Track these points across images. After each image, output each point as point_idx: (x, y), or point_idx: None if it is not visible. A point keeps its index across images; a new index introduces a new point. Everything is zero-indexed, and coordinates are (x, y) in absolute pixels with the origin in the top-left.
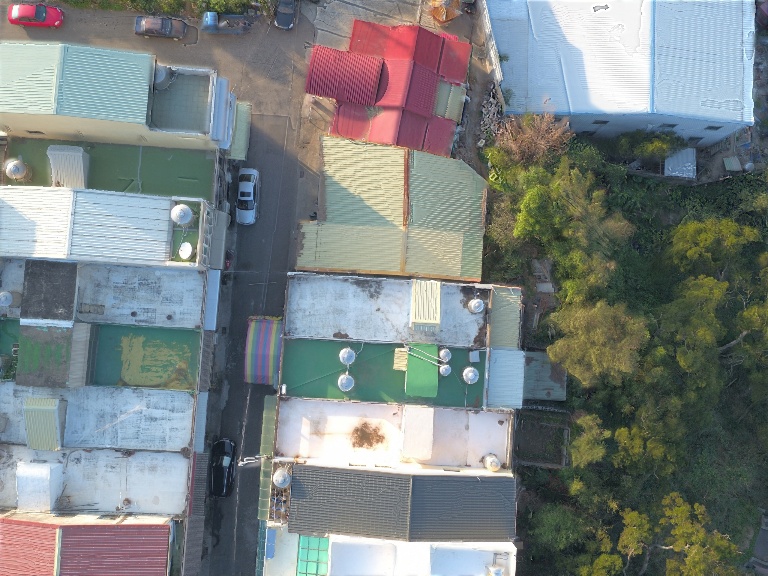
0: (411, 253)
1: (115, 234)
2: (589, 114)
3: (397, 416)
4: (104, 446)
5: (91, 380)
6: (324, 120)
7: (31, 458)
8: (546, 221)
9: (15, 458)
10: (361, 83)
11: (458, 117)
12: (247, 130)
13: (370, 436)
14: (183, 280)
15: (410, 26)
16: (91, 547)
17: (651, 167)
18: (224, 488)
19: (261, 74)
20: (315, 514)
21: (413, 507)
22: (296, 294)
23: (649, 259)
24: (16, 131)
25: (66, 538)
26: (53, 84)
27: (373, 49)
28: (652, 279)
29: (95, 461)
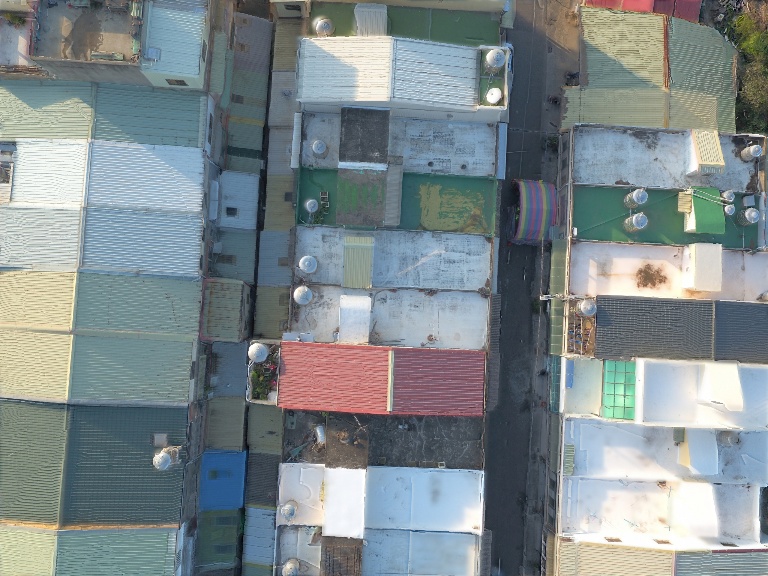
0: (674, 112)
1: (429, 80)
2: None
3: (678, 258)
4: (408, 286)
5: None
6: None
7: None
8: None
9: (326, 298)
10: None
11: None
12: (514, 1)
13: (653, 276)
14: (474, 133)
15: None
16: (419, 369)
17: None
18: None
19: None
20: (608, 347)
21: (717, 329)
22: (579, 145)
23: None
24: None
25: (398, 359)
26: None
27: None
28: None
29: (400, 301)
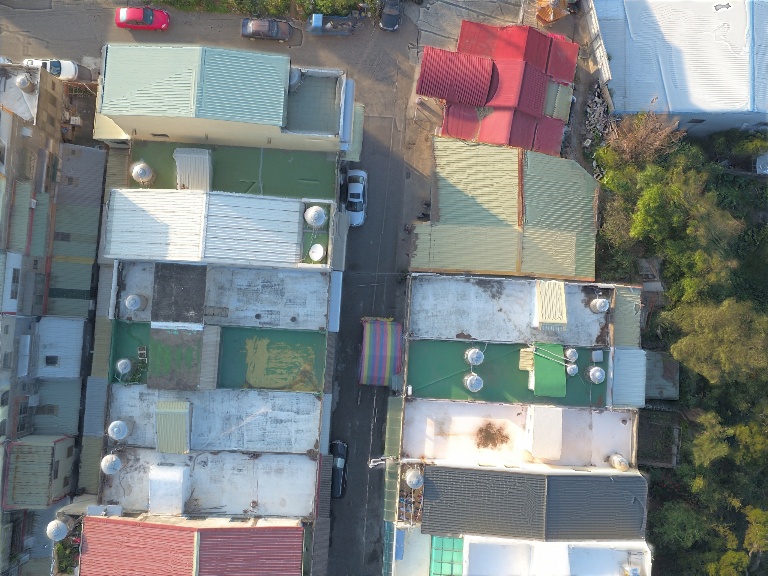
0: (527, 253)
1: (246, 236)
2: (688, 113)
3: (521, 416)
4: (231, 449)
5: (218, 383)
6: (429, 121)
7: (158, 461)
8: (664, 220)
9: (142, 461)
10: (472, 84)
11: (566, 117)
12: (360, 131)
13: (494, 437)
14: (306, 282)
15: (519, 26)
16: (228, 550)
17: (743, 166)
18: (340, 490)
19: (366, 75)
20: (443, 515)
21: (549, 507)
22: (418, 295)
23: (742, 258)
24: (140, 134)
25: (204, 541)
26: (191, 87)
27: (481, 50)
28: (747, 277)
29: (222, 464)
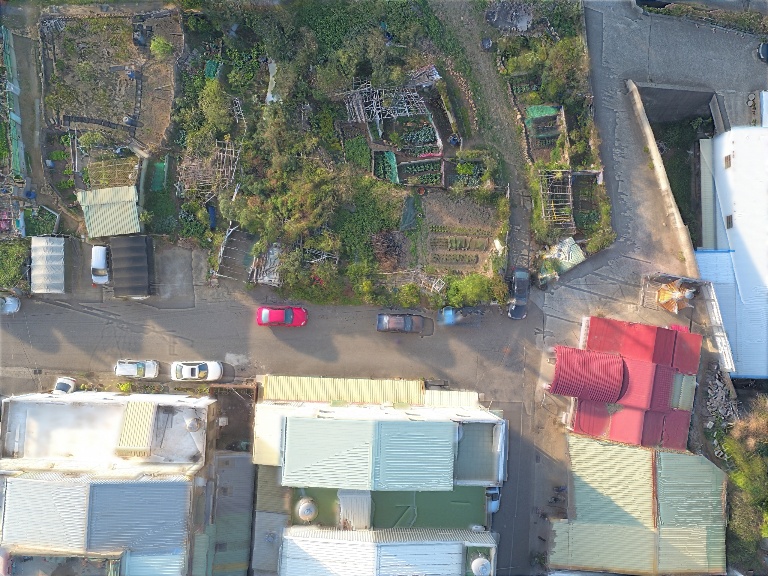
0: (663, 554)
1: None
2: None
3: None
4: None
5: None
6: (557, 405)
7: None
8: None
9: None
10: (605, 385)
11: (690, 405)
12: None
13: None
14: None
15: (647, 325)
16: None
17: None
18: None
19: (495, 362)
20: None
21: None
22: None
23: None
24: None
25: None
26: (369, 461)
27: (610, 345)
28: None
29: None
